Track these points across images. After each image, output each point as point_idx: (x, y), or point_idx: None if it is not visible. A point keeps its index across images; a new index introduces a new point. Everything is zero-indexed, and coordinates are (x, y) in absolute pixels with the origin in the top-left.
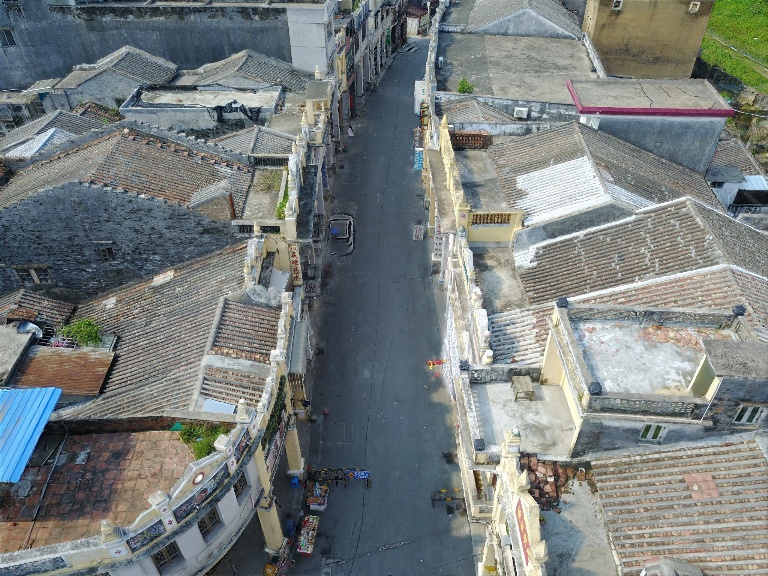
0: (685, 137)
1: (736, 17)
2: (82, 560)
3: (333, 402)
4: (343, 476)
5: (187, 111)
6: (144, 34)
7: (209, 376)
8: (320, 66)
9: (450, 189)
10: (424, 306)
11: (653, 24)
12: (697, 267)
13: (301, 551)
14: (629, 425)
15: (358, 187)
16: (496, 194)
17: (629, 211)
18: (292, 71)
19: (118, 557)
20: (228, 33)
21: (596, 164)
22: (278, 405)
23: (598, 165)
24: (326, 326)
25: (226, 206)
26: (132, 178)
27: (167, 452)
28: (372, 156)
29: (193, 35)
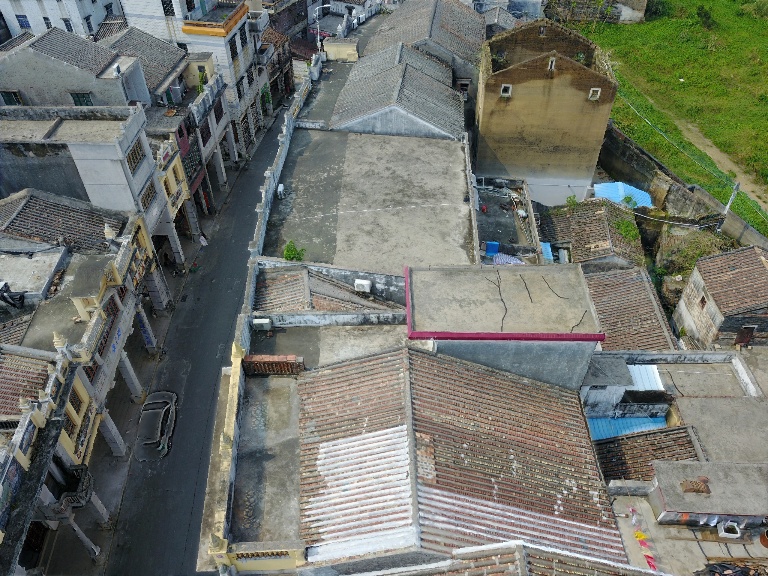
0: (548, 358)
1: (663, 48)
2: None
3: None
4: None
5: None
6: None
7: None
8: (126, 204)
9: None
10: None
11: (549, 111)
12: None
13: None
14: None
15: (198, 333)
16: (289, 477)
17: (442, 556)
18: (92, 211)
19: None
20: None
21: (414, 446)
22: None
23: (417, 446)
24: None
25: None
26: None
27: None
28: (224, 279)
29: None
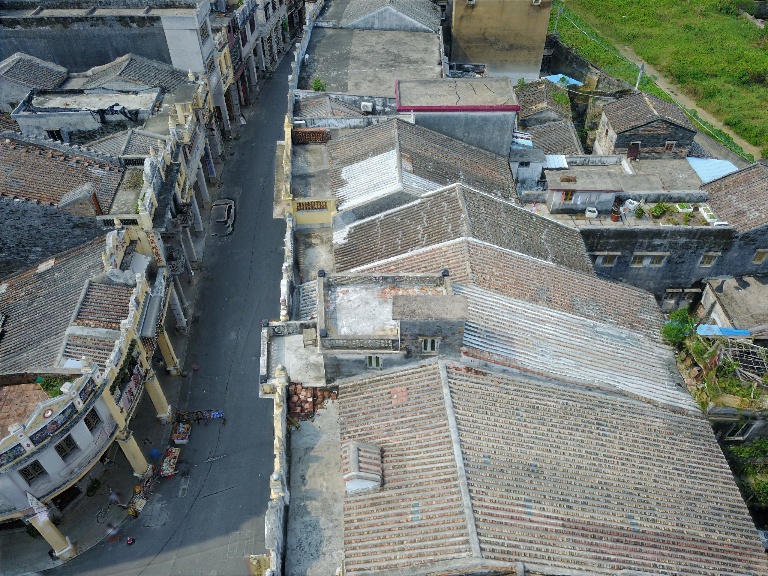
0: (486, 128)
1: None
2: None
3: (202, 360)
4: (202, 417)
5: (73, 115)
6: (33, 42)
7: (71, 342)
8: (198, 66)
9: None
10: None
11: (504, 15)
12: (449, 240)
13: None
14: (355, 357)
15: (244, 173)
16: (325, 183)
17: (415, 196)
18: (173, 72)
19: None
20: (110, 39)
21: (400, 156)
22: (127, 361)
23: (402, 157)
24: (203, 298)
25: (90, 205)
26: (11, 183)
27: (31, 398)
28: (260, 143)
29: (78, 42)
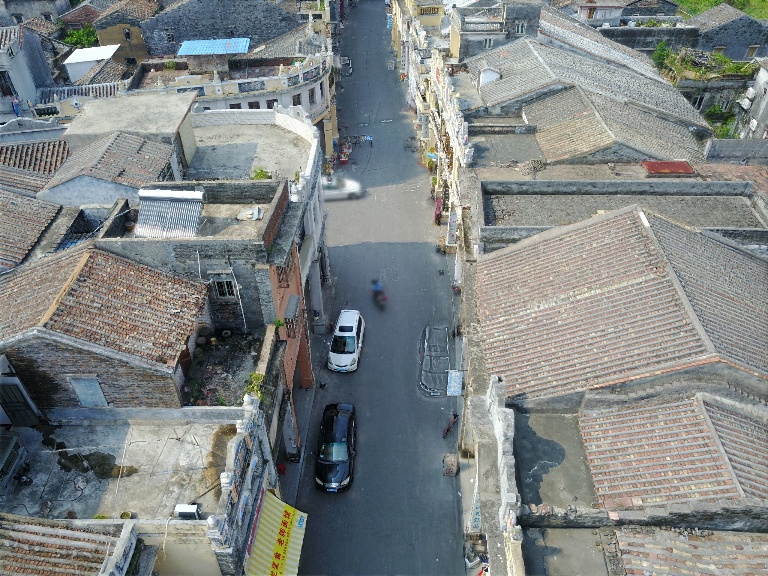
0: None
1: None
2: (270, 87)
3: (349, 124)
4: (359, 140)
5: None
6: None
7: None
8: None
9: (408, 6)
10: (396, 93)
11: None
12: None
13: (342, 159)
14: (478, 39)
15: (351, 50)
16: None
17: (496, 1)
18: None
19: (283, 87)
20: None
21: None
22: (332, 72)
23: None
24: (341, 102)
25: (295, 3)
26: None
27: None
28: (358, 36)
29: None
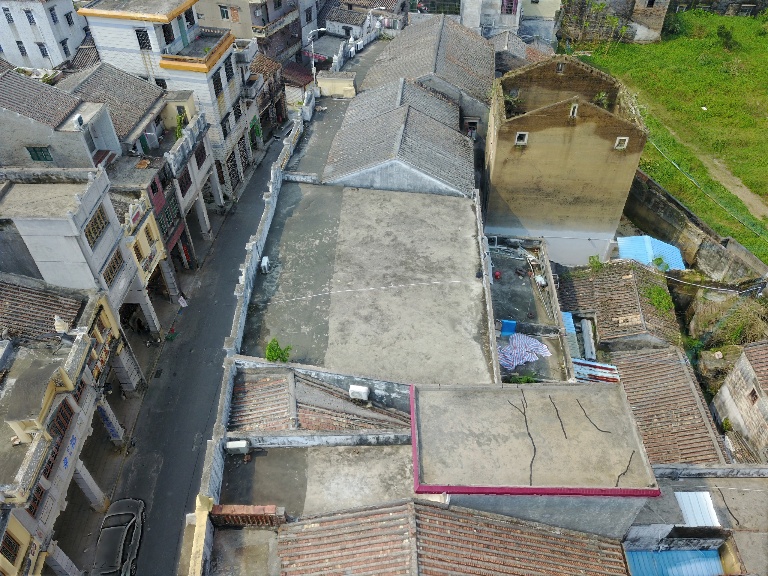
0: (587, 509)
1: (682, 72)
2: None
3: None
4: None
5: None
6: None
7: None
8: (86, 282)
9: None
10: None
11: (569, 161)
12: None
13: None
14: None
15: (172, 418)
16: None
17: None
18: (46, 289)
19: None
20: None
21: None
22: None
23: None
24: None
25: None
26: None
27: None
28: (204, 349)
29: None
